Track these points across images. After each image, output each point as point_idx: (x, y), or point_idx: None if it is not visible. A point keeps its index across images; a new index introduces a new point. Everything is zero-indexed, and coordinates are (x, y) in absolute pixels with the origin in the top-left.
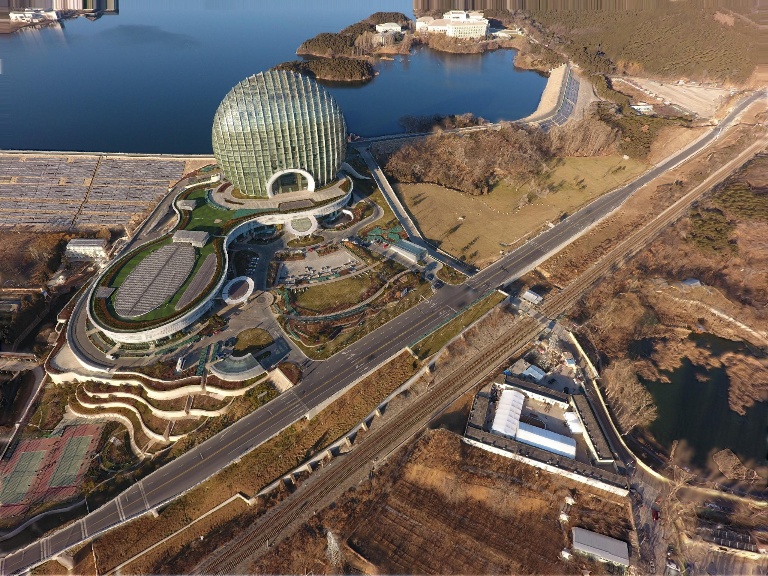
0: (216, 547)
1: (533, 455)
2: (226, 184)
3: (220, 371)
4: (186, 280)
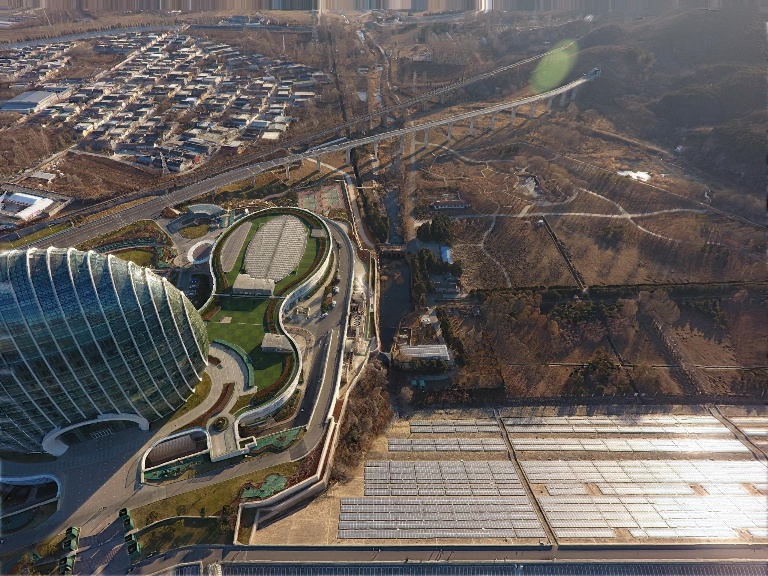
0: (219, 172)
1: (41, 191)
2: (221, 406)
3: (217, 206)
4: (248, 244)
